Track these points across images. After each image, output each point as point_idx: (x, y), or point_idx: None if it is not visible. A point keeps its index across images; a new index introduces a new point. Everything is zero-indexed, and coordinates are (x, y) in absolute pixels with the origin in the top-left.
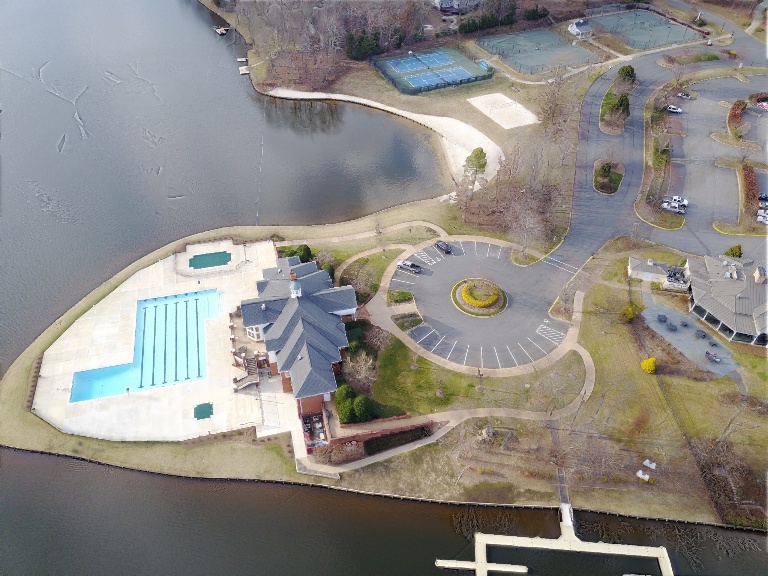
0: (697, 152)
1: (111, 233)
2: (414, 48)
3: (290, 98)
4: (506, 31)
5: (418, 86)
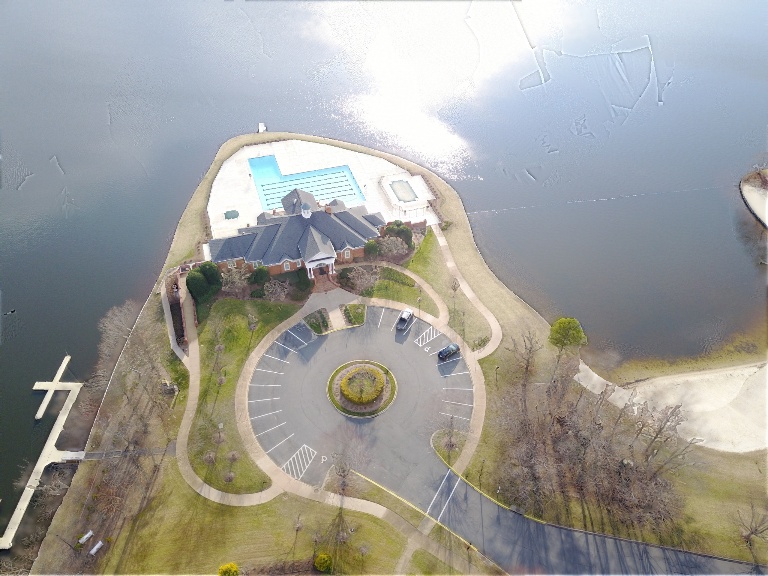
0: None
1: (466, 154)
2: None
3: (748, 204)
4: None
5: None
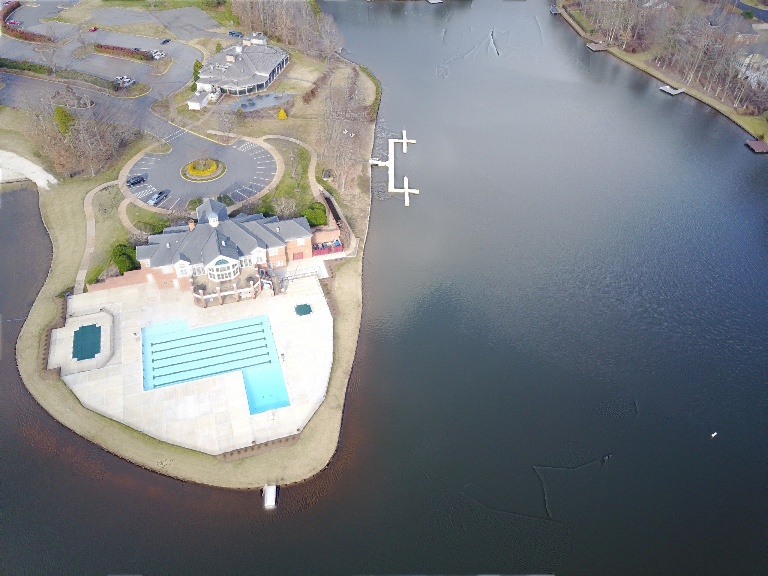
0: (58, 61)
1: None
2: None
3: None
4: None
5: None
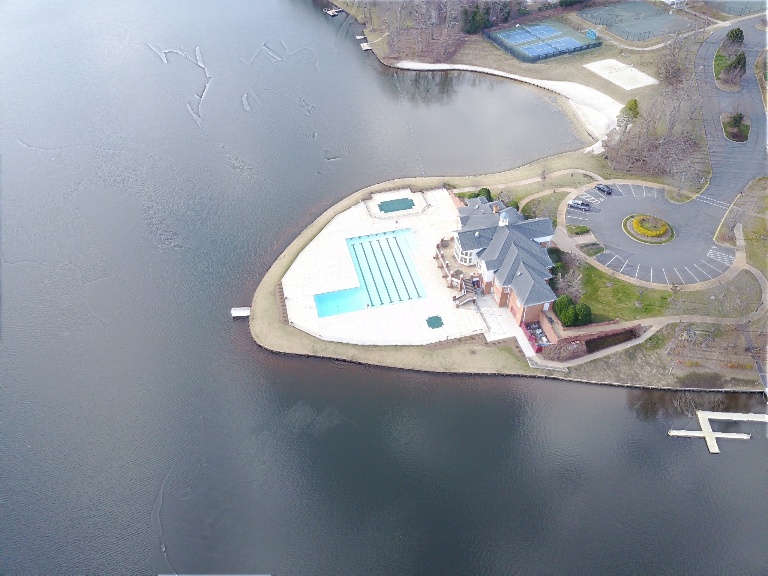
0: None
1: None
2: (520, 21)
3: (417, 69)
4: (603, 3)
5: (537, 54)
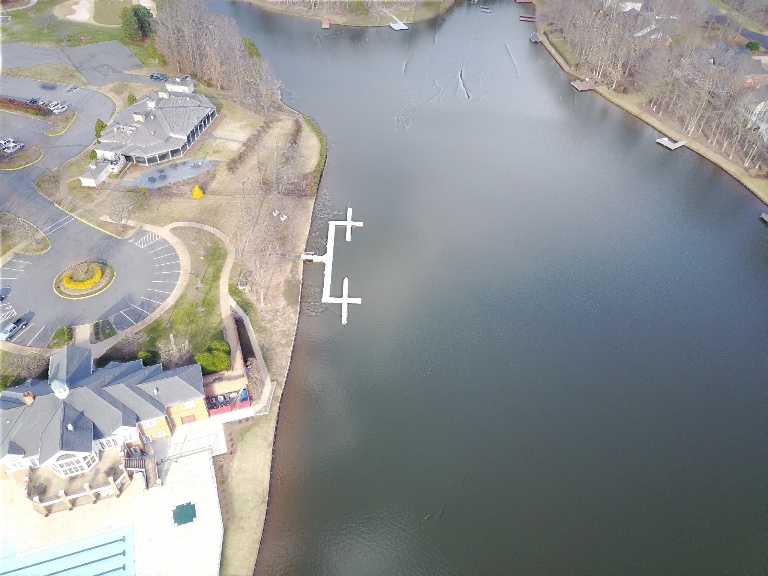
0: None
1: None
2: None
3: None
4: None
5: None
